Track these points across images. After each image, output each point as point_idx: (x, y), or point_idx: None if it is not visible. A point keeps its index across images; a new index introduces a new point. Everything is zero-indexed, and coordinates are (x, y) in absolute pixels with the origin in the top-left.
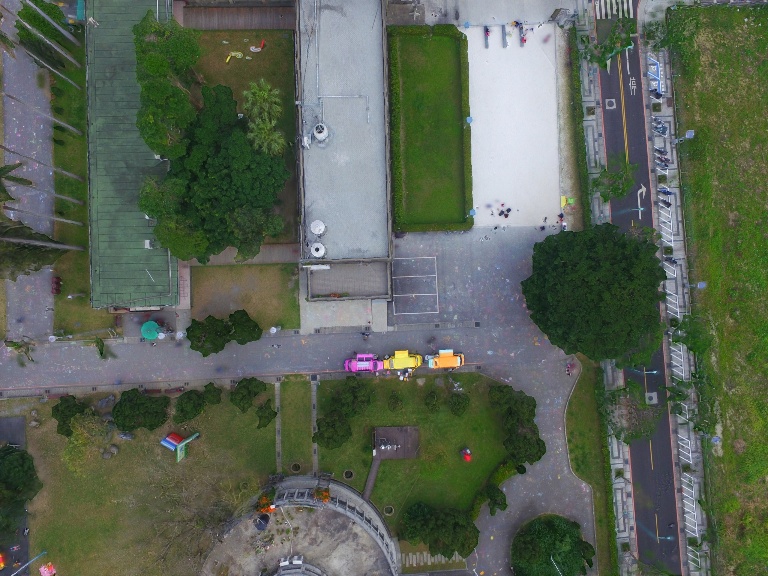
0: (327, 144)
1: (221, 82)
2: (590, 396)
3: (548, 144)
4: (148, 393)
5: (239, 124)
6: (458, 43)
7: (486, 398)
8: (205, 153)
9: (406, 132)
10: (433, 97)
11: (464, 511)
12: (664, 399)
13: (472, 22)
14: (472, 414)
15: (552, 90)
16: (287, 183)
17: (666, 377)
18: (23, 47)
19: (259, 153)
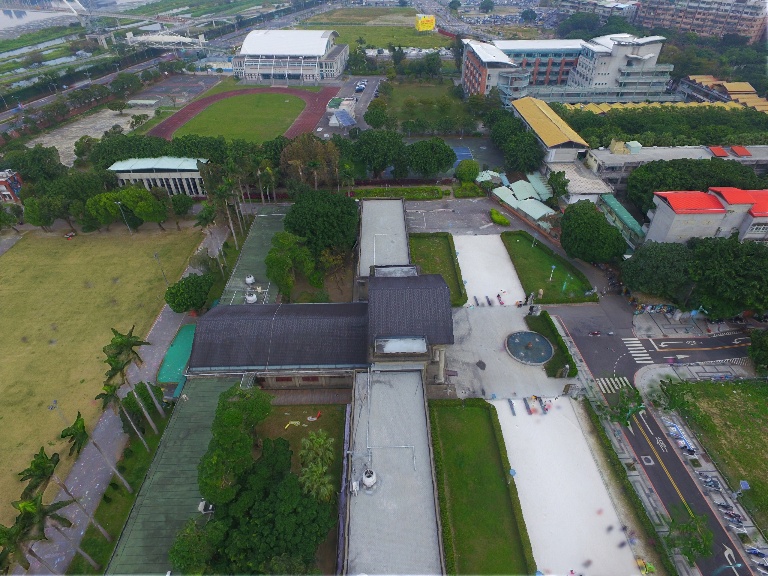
0: (375, 491)
1: None
2: None
3: (600, 500)
4: None
5: None
6: (488, 412)
7: None
8: (253, 498)
9: (450, 489)
10: (473, 456)
11: None
12: None
13: (497, 397)
14: None
15: (585, 449)
16: (326, 543)
17: None
18: (124, 410)
19: (307, 497)
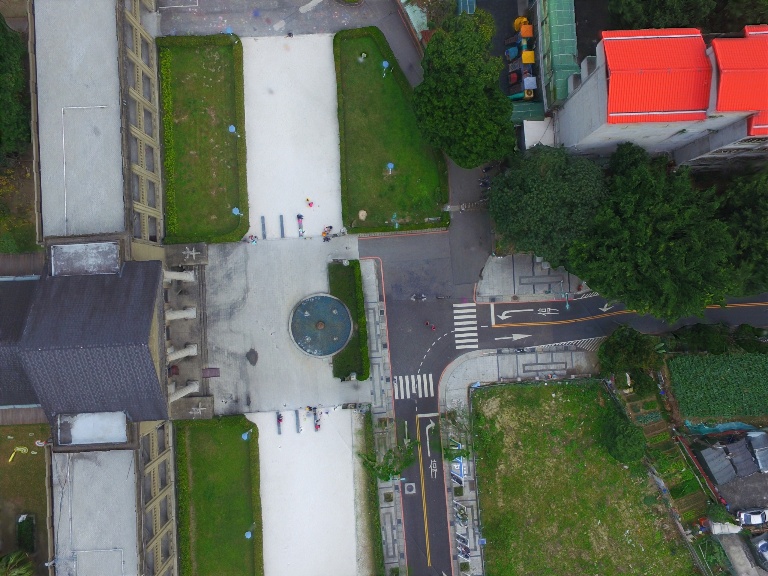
0: None
1: (6, 478)
2: None
3: (345, 531)
4: None
5: (22, 526)
6: None
7: None
8: None
9: (197, 523)
10: (224, 487)
11: None
12: None
13: (264, 408)
14: None
15: (349, 475)
16: None
17: None
18: None
19: None
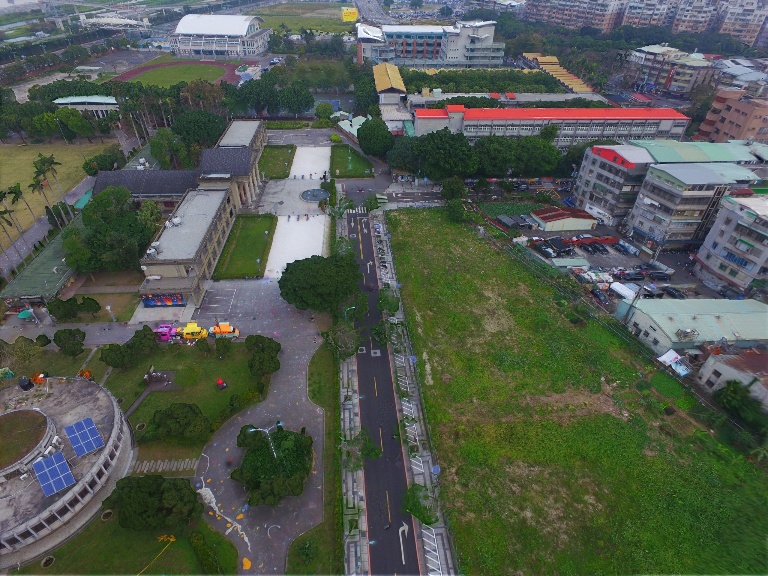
0: (179, 227)
1: None
2: (329, 352)
3: (316, 249)
4: None
5: None
6: None
7: (249, 355)
8: None
9: (236, 246)
10: (255, 235)
11: None
12: (386, 354)
13: None
14: (235, 364)
15: (321, 233)
16: None
17: (387, 342)
18: None
19: None
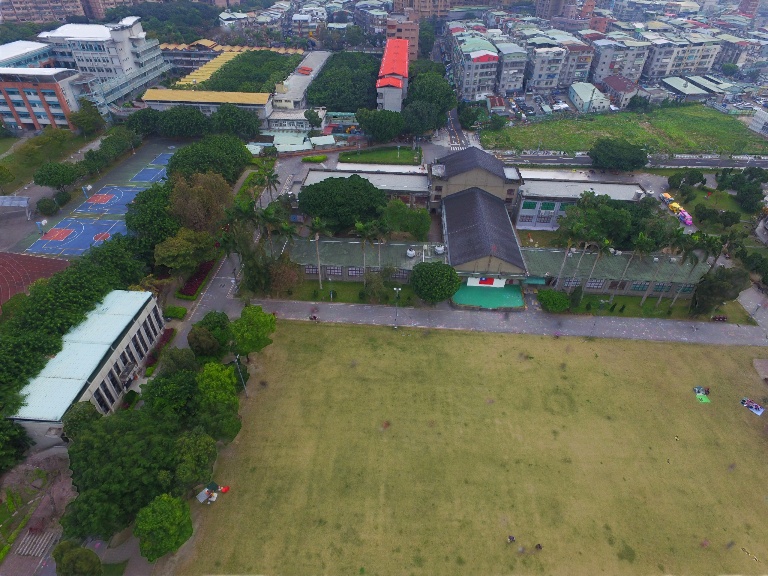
0: None
1: None
2: None
3: None
4: (760, 286)
5: None
6: None
7: None
8: None
9: None
10: None
11: (735, 199)
12: None
13: None
14: None
15: None
16: None
17: None
18: None
19: None
